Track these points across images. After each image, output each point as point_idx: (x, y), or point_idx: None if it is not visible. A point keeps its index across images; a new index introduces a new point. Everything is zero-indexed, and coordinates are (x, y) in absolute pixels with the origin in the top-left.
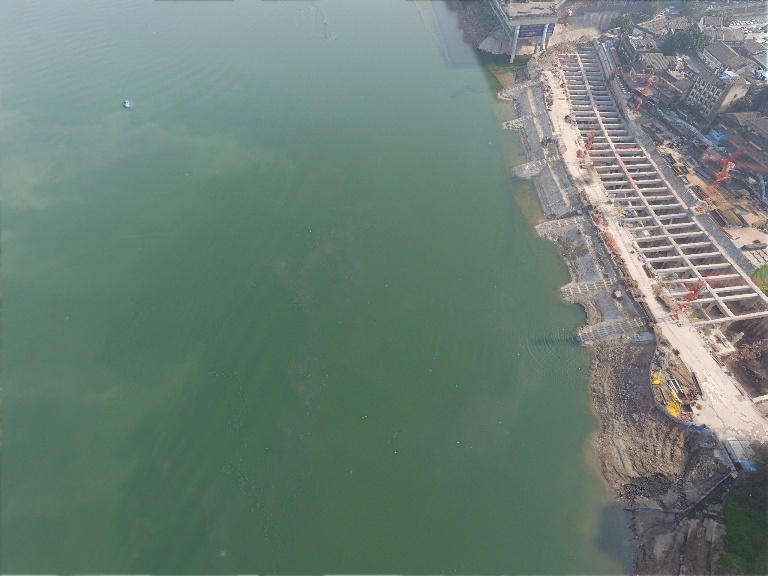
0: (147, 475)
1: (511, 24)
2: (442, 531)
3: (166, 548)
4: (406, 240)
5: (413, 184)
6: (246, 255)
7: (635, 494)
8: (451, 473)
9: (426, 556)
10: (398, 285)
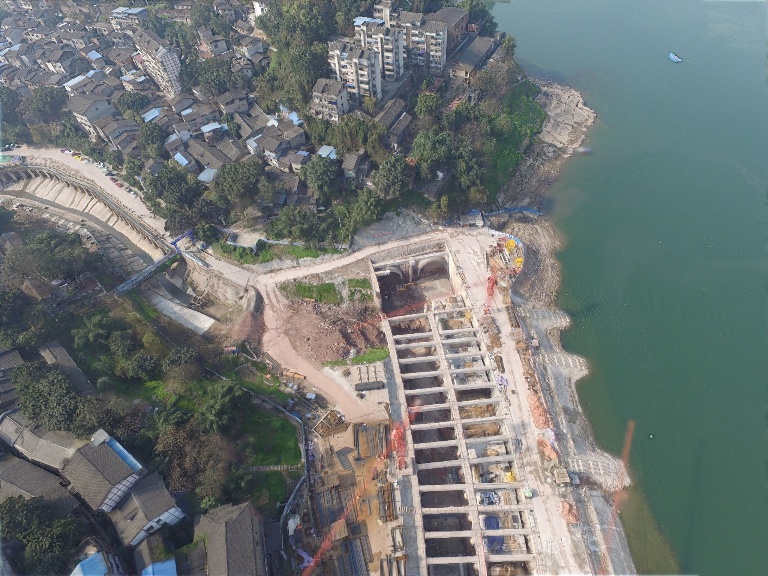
0: None
1: None
2: (655, 205)
3: None
4: None
5: None
6: None
7: (537, 220)
8: (659, 228)
9: (661, 196)
10: None
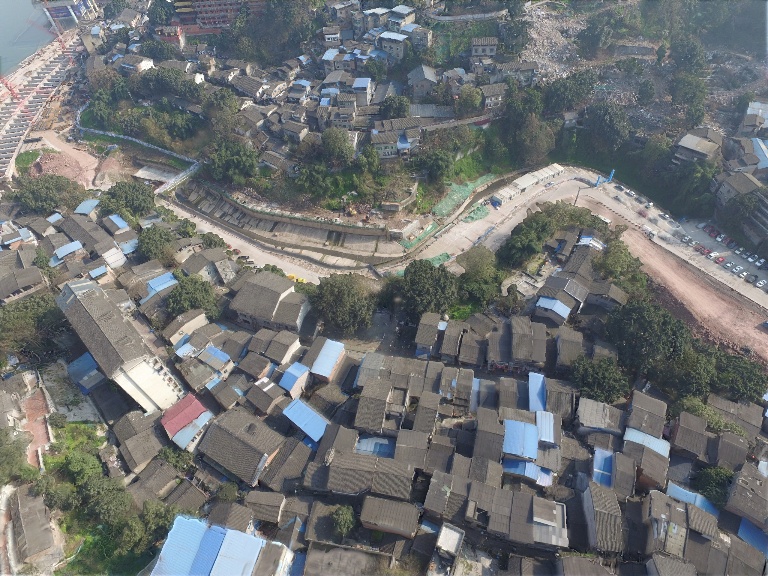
0: None
1: (36, 7)
2: None
3: None
4: None
5: None
6: None
7: None
8: None
9: None
10: None
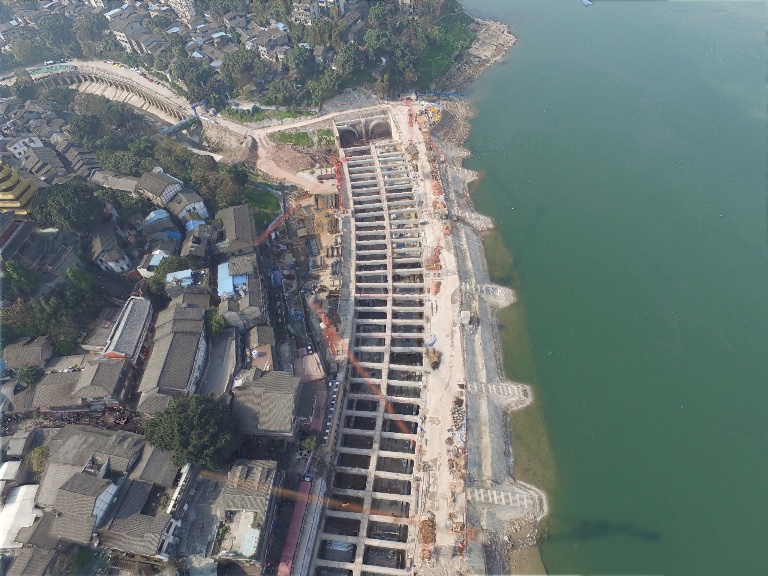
0: (705, 100)
1: None
2: (547, 91)
3: (670, 81)
4: (618, 215)
5: (639, 277)
6: (764, 188)
7: (458, 101)
8: (546, 104)
9: (553, 86)
10: (610, 178)
